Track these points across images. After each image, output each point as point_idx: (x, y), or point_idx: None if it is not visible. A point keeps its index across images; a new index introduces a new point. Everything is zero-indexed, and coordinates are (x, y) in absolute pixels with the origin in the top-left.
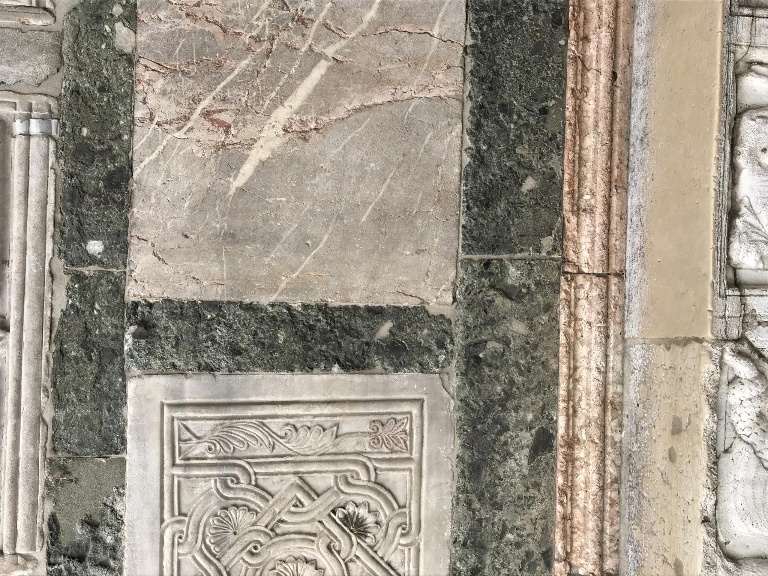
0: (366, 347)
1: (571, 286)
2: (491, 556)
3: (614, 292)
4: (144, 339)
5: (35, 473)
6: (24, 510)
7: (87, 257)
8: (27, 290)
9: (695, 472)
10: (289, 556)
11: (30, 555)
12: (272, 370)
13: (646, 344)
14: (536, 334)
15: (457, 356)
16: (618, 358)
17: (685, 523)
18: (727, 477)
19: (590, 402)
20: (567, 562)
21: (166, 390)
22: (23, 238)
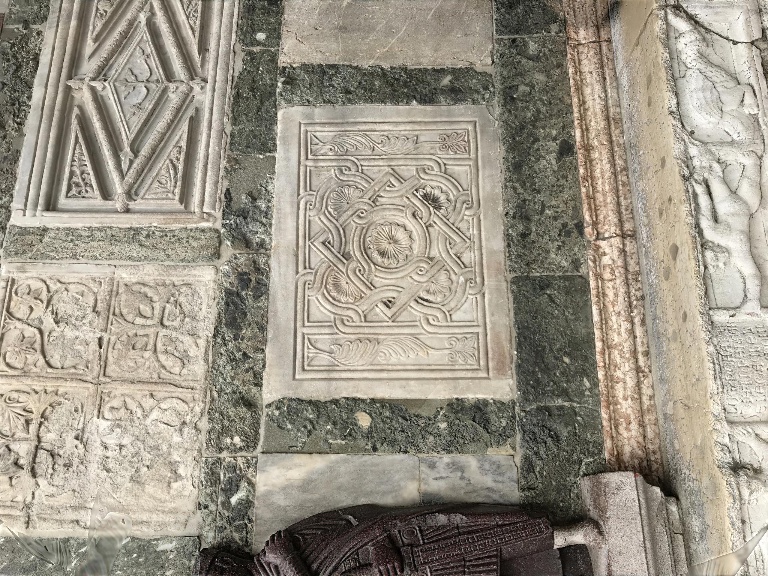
0: (434, 91)
1: (574, 51)
2: (535, 226)
3: (605, 50)
4: (289, 85)
5: (218, 164)
6: (210, 185)
7: (256, 42)
8: (219, 60)
9: (660, 89)
10: (386, 221)
11: (212, 215)
12: (372, 103)
13: (628, 61)
14: (553, 81)
15: (498, 94)
16: (614, 91)
17: (661, 129)
18: (684, 91)
19: (597, 120)
20: (594, 228)
21: (303, 115)
22: (219, 33)
